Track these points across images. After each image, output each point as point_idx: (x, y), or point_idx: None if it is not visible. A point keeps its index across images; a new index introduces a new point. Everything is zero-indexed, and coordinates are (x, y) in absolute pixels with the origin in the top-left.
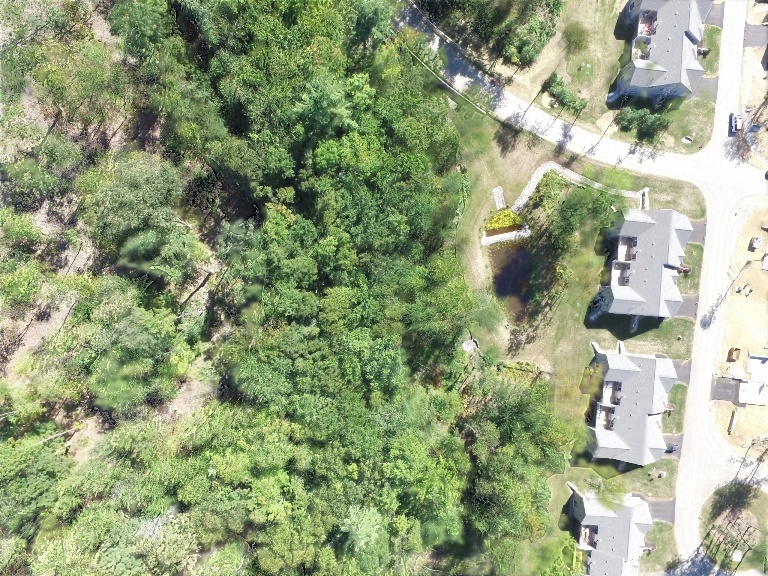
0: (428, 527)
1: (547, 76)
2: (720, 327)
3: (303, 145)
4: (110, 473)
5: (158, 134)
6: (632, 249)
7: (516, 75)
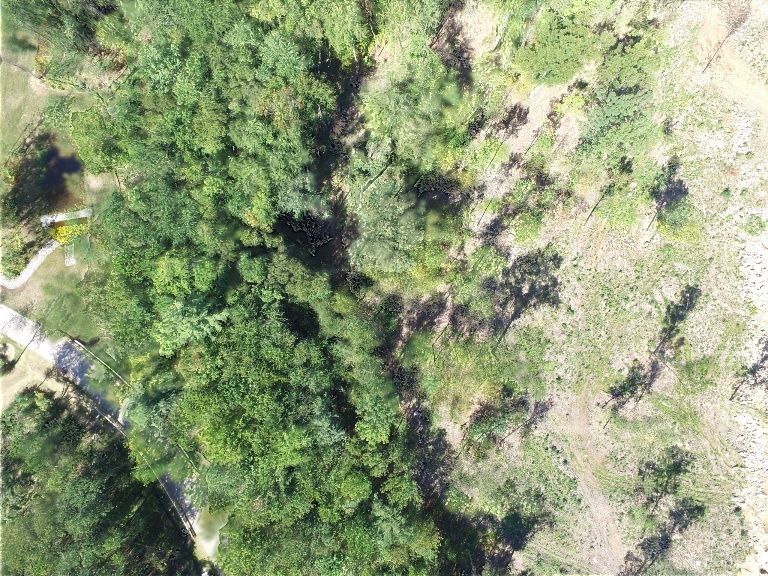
0: None
1: (8, 378)
2: None
3: (230, 286)
4: (453, 2)
5: (404, 330)
6: None
7: (42, 380)
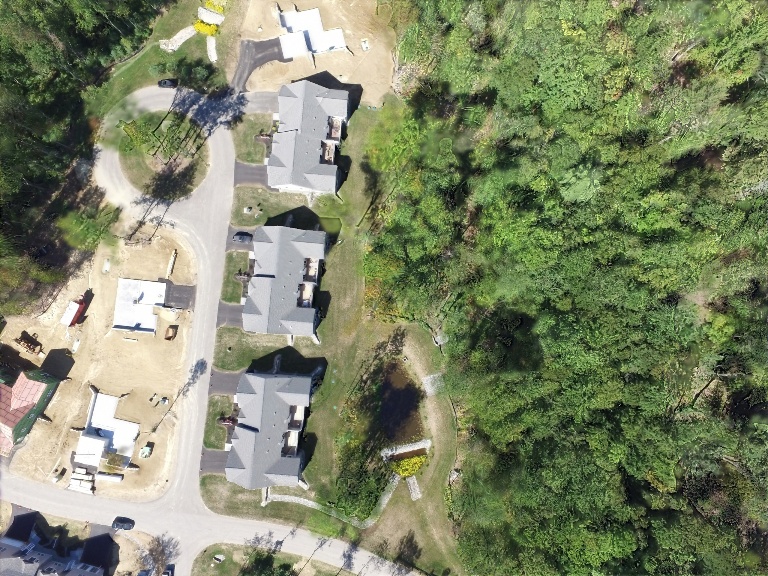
0: (506, 176)
1: None
2: (185, 361)
3: (645, 552)
4: None
5: (744, 541)
6: (285, 444)
7: None
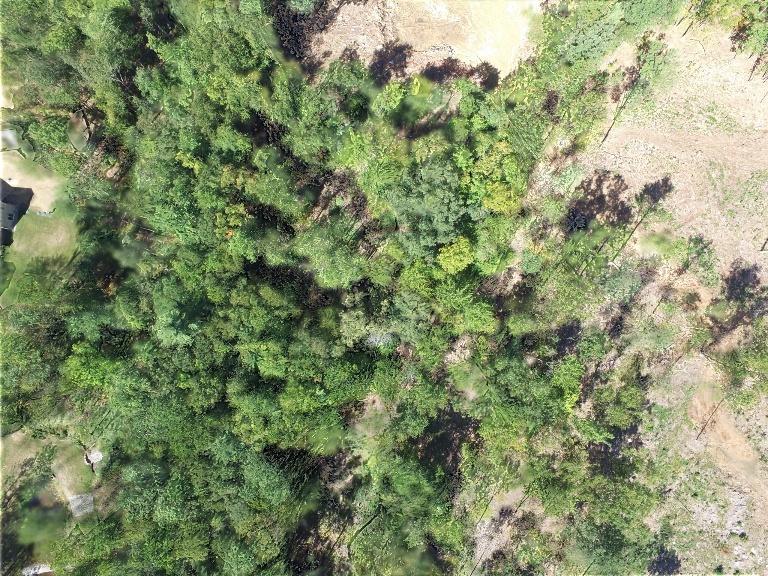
0: None
1: None
2: None
3: None
4: None
5: None
6: None
7: None
